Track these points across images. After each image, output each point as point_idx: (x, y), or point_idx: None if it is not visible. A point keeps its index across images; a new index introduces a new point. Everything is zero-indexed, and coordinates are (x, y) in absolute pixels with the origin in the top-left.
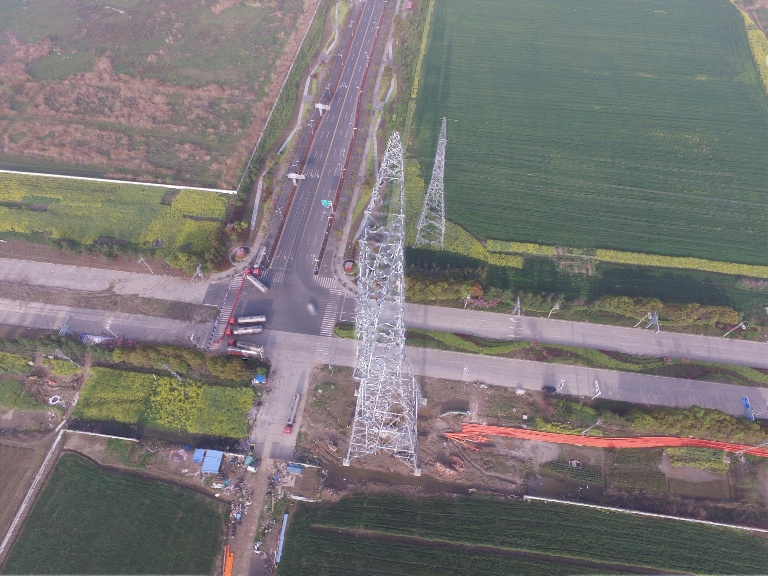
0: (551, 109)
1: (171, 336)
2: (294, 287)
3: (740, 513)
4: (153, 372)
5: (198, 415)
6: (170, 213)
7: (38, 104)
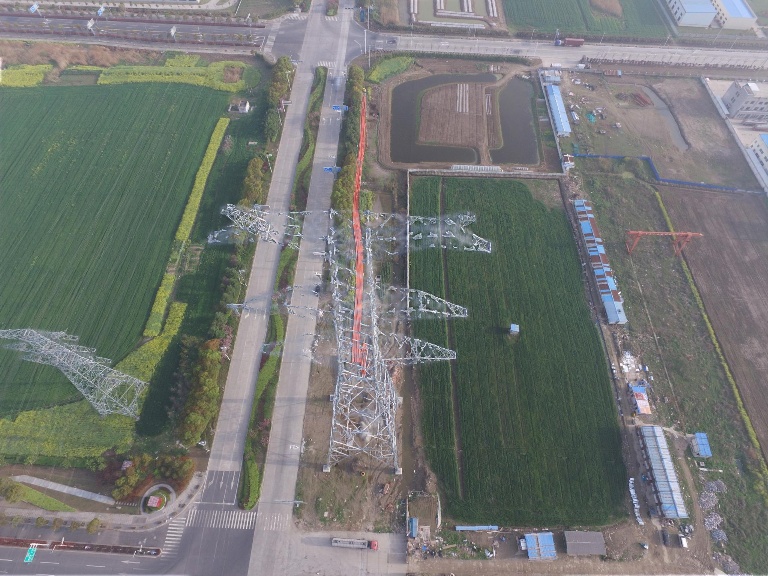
0: None
1: None
2: None
3: (399, 192)
4: None
5: None
6: None
7: None
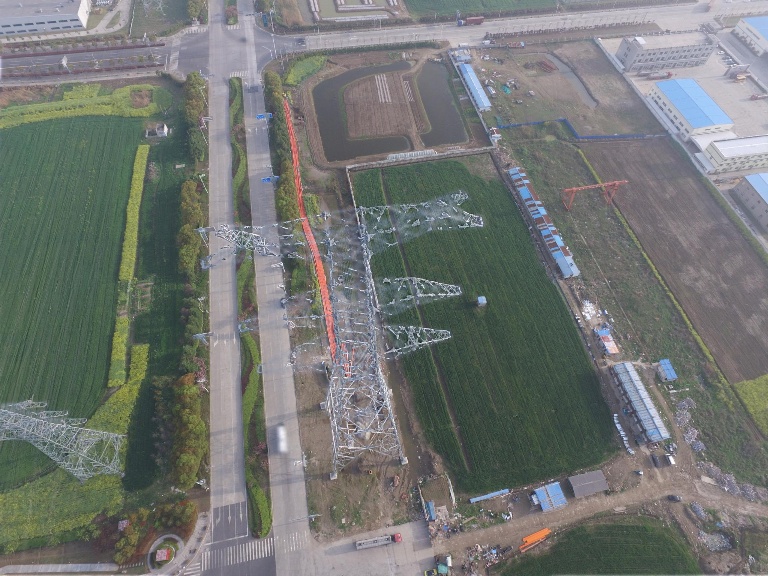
0: None
1: None
2: None
3: (342, 190)
4: None
5: None
6: None
7: None
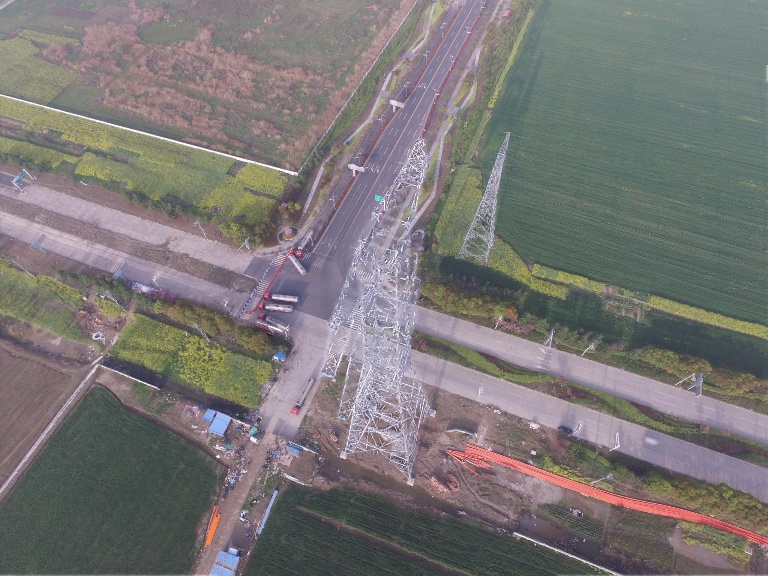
0: (634, 140)
1: (209, 299)
2: (331, 275)
3: None
4: (186, 329)
5: (217, 378)
6: (233, 184)
7: (140, 65)
